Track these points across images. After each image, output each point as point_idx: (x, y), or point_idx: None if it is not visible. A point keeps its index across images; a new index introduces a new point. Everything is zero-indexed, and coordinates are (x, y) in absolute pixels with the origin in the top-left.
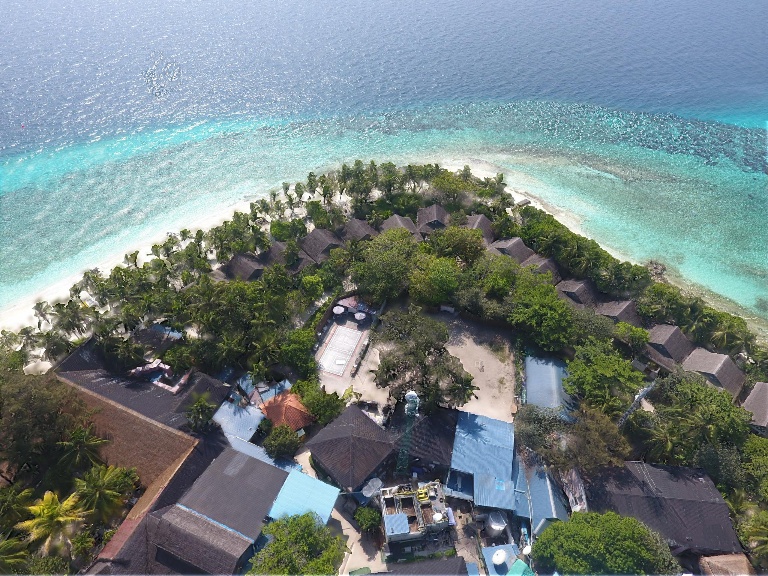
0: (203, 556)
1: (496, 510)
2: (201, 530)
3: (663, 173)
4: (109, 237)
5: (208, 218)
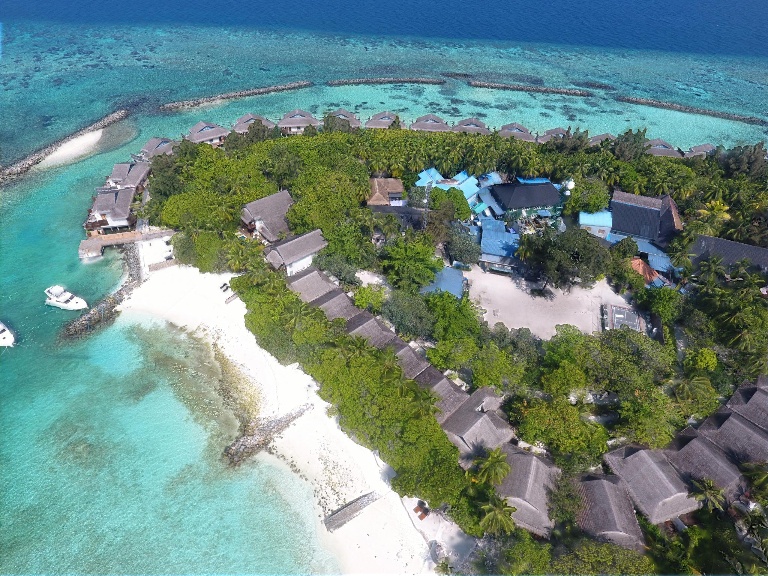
0: None
1: None
2: (639, 198)
3: None
4: None
5: None
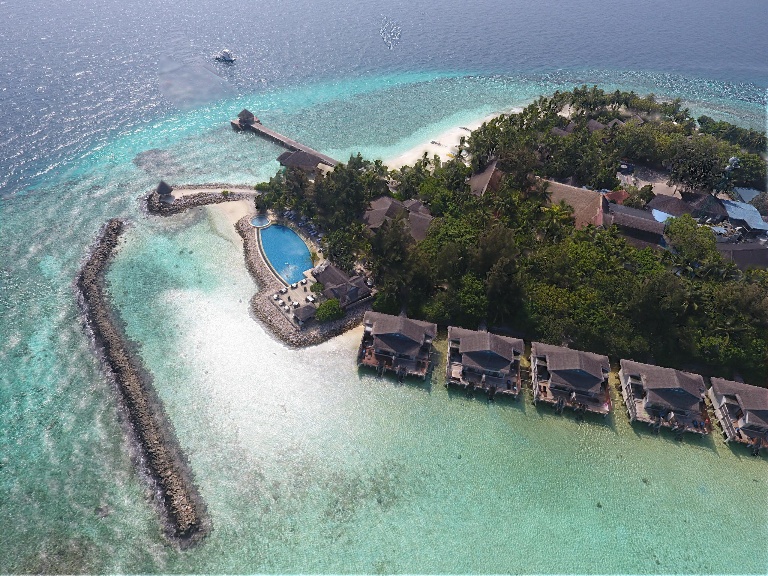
0: (645, 225)
1: (760, 233)
2: None
3: (764, 115)
4: (423, 128)
5: (479, 121)
